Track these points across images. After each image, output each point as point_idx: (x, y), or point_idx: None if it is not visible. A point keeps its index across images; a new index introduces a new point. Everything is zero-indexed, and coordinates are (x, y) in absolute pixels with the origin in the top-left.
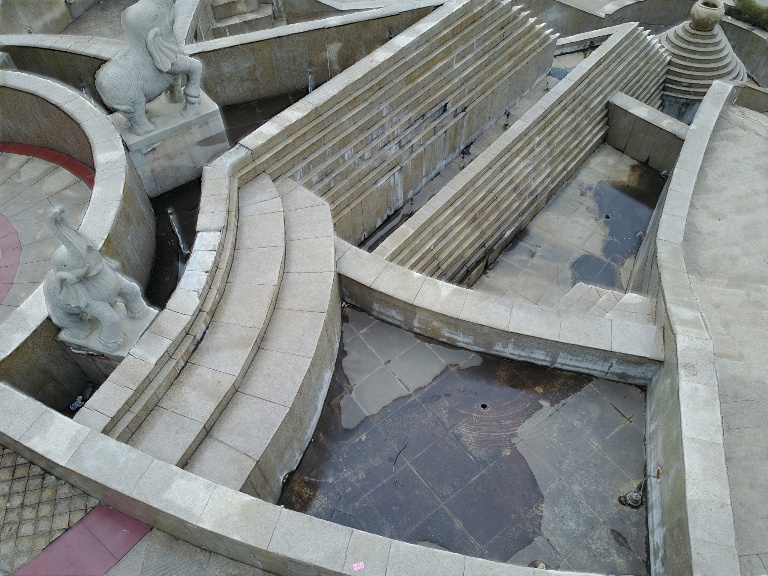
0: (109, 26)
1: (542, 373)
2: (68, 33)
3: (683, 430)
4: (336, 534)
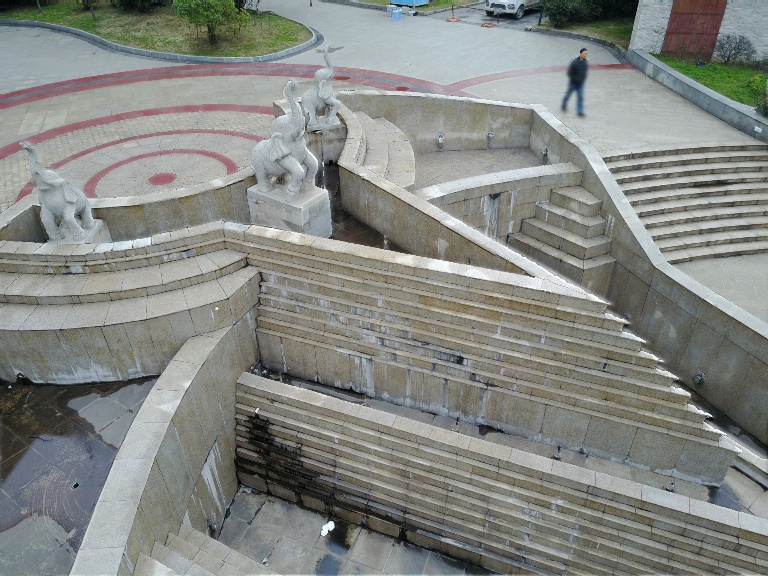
0: (494, 163)
1: None
2: (471, 152)
3: None
4: None
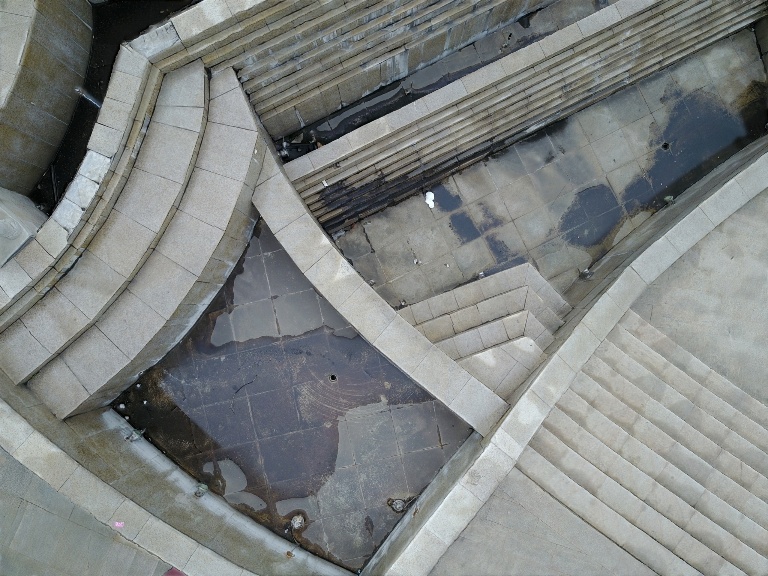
0: None
1: (400, 372)
2: None
3: (428, 522)
4: (111, 498)
